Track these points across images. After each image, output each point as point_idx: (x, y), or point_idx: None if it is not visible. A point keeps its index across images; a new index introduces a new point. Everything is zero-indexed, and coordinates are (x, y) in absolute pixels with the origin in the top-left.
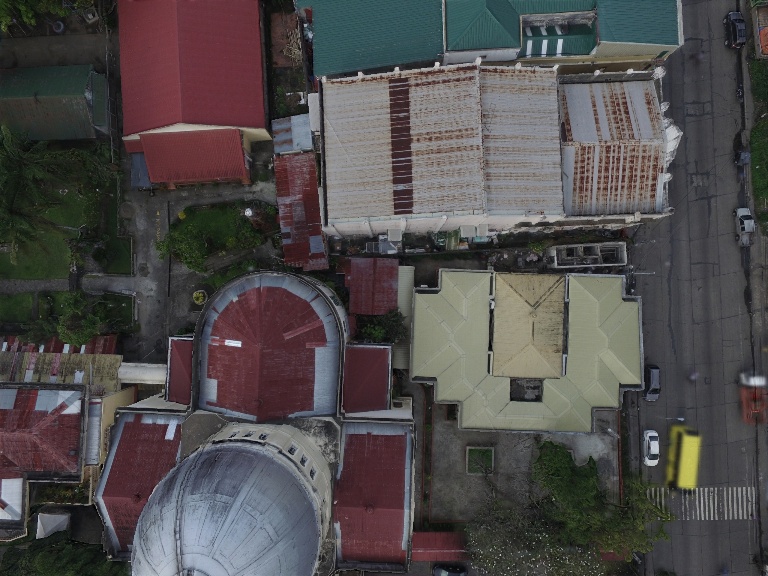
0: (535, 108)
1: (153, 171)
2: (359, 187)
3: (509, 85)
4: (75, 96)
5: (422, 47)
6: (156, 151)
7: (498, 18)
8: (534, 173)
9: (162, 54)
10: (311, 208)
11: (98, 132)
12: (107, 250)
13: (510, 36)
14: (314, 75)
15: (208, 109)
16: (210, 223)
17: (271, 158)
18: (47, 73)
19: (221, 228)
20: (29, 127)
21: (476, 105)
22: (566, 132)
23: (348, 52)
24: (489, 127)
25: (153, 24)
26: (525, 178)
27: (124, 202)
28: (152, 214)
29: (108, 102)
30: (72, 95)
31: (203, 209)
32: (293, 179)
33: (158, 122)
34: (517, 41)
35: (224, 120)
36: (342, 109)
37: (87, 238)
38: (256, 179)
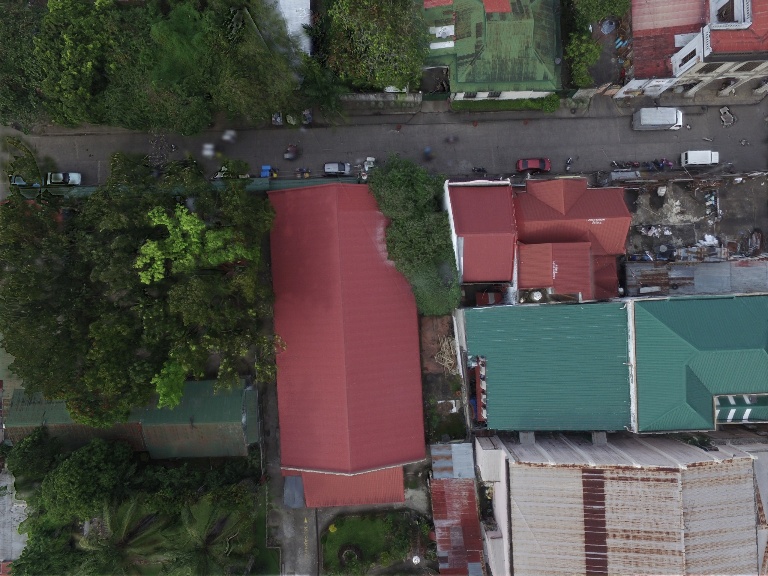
0: (732, 499)
1: (310, 498)
2: (549, 575)
3: (707, 478)
4: (232, 423)
5: (606, 415)
6: (316, 482)
7: (695, 407)
8: (732, 567)
9: (327, 394)
10: (470, 534)
11: (249, 446)
12: (257, 565)
13: (705, 421)
14: (488, 428)
15: (374, 450)
16: (359, 532)
17: (428, 479)
18: (200, 391)
19: (370, 537)
20: (182, 447)
21: (678, 509)
22: (758, 512)
23: (525, 410)
24: (688, 525)
25: (316, 359)
26: (723, 574)
27: (271, 509)
28: (300, 521)
29: (257, 412)
30: (229, 422)
31: (352, 517)
32: (451, 503)
33: (323, 463)
34: (711, 423)
35: (389, 458)
36: (530, 492)
37: (238, 556)
38: (406, 487)
